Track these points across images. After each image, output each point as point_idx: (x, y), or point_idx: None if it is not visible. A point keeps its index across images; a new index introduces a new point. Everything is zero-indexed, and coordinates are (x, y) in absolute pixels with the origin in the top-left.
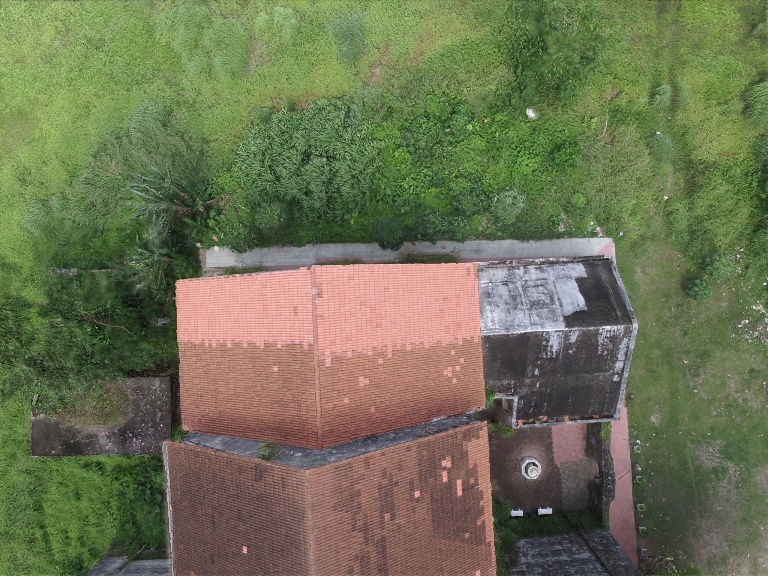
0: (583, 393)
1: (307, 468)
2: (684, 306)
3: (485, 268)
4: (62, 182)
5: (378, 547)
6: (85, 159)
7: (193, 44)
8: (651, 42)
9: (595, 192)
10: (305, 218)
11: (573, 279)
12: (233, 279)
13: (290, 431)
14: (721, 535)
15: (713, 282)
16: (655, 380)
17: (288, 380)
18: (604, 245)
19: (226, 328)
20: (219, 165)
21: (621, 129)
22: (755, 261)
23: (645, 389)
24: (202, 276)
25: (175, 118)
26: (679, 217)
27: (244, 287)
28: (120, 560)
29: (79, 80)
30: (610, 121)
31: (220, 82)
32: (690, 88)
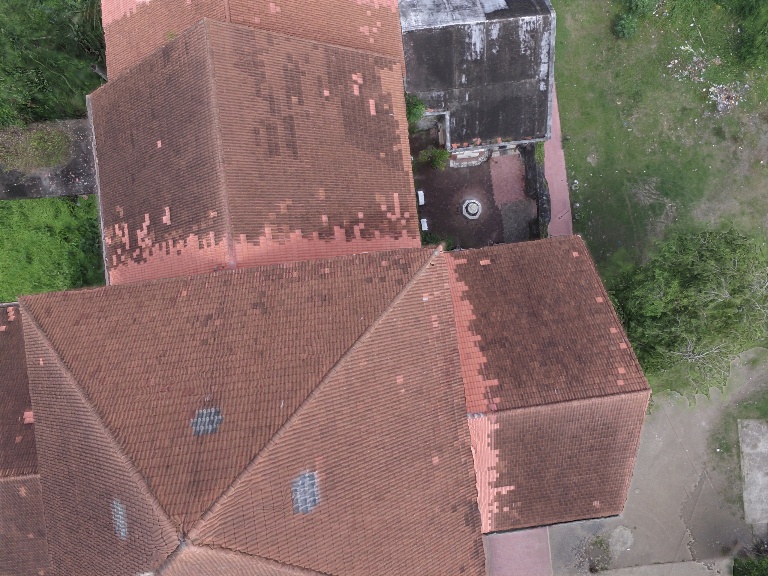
0: (512, 107)
1: None
2: (615, 49)
3: None
4: None
5: (285, 123)
6: None
7: None
8: None
9: None
10: None
11: None
12: None
13: None
14: None
15: (642, 25)
16: (590, 122)
17: (200, 5)
18: None
19: None
20: None
21: None
22: (681, 1)
23: (580, 131)
24: None
25: None
26: None
27: None
28: None
29: None
30: None
31: None
32: None
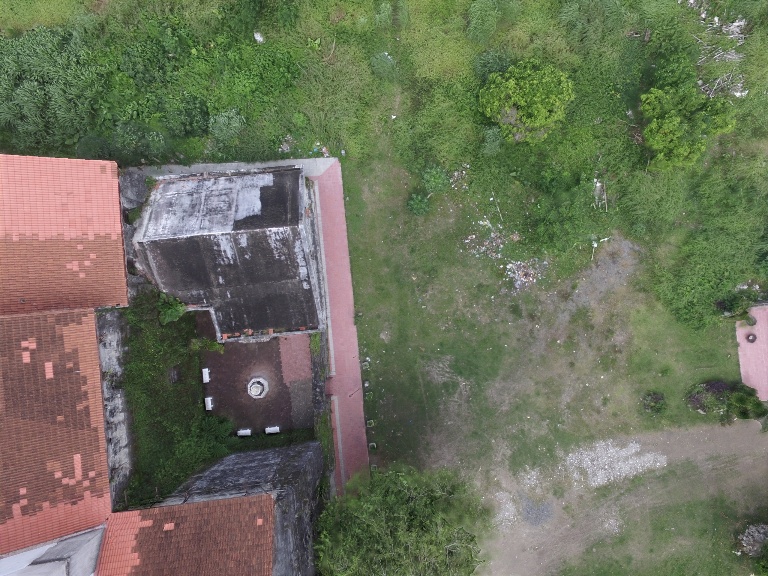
0: (279, 303)
1: None
2: (411, 223)
3: (177, 181)
4: None
5: None
6: None
7: None
8: None
9: (316, 111)
10: (23, 144)
11: (258, 188)
12: None
13: None
14: (452, 449)
15: (440, 199)
16: (384, 297)
17: None
18: (330, 165)
19: None
20: None
21: (343, 49)
22: (479, 176)
23: (374, 306)
24: None
25: None
26: (402, 134)
27: None
28: None
29: None
30: (337, 43)
31: None
32: (417, 8)
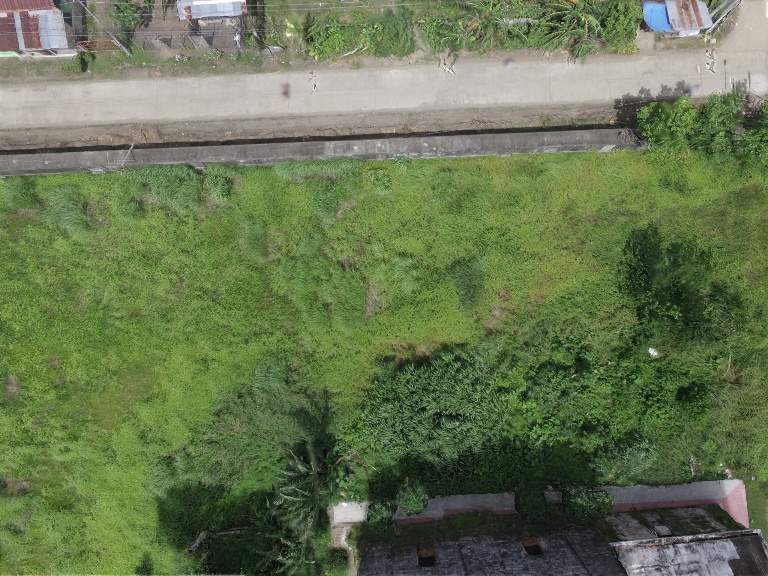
0: None
1: None
2: None
3: (634, 548)
4: (184, 439)
5: None
6: (207, 416)
7: (313, 297)
8: None
9: (725, 437)
10: (437, 478)
11: (726, 562)
12: None
13: None
14: None
15: None
16: None
17: None
18: (734, 487)
19: None
20: (345, 422)
21: (748, 371)
22: None
23: None
24: (331, 532)
25: (298, 373)
26: None
27: None
28: None
29: (197, 334)
30: (734, 358)
31: (340, 332)
32: None
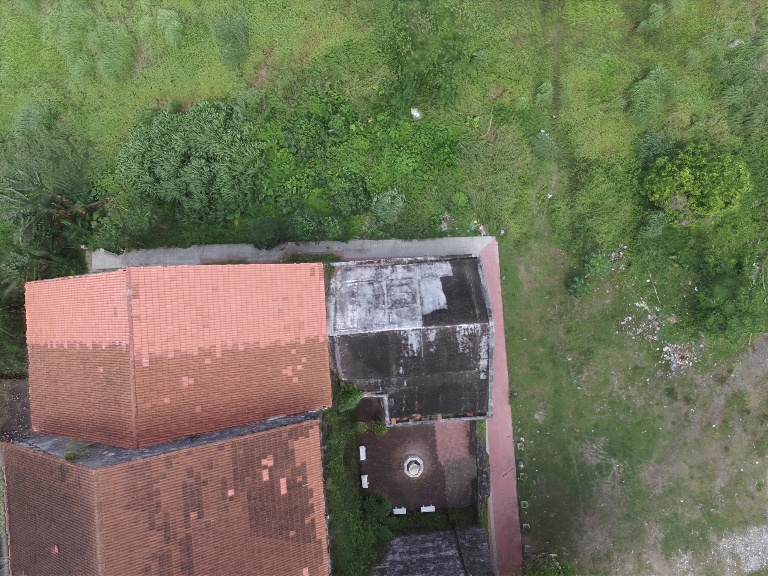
0: (452, 391)
1: (95, 468)
2: (567, 304)
3: (354, 268)
4: None
5: (182, 545)
6: None
7: (78, 47)
8: (536, 41)
9: (476, 191)
10: (186, 219)
11: (438, 278)
12: (68, 281)
13: (112, 431)
14: (605, 531)
15: (596, 279)
16: (539, 377)
17: (110, 381)
18: (487, 243)
19: (64, 330)
20: (103, 167)
21: (503, 128)
22: (637, 258)
23: (529, 387)
24: None
25: (60, 121)
26: (561, 215)
27: (77, 289)
28: (0, 560)
29: None
30: (494, 120)
31: (106, 85)
32: (574, 86)
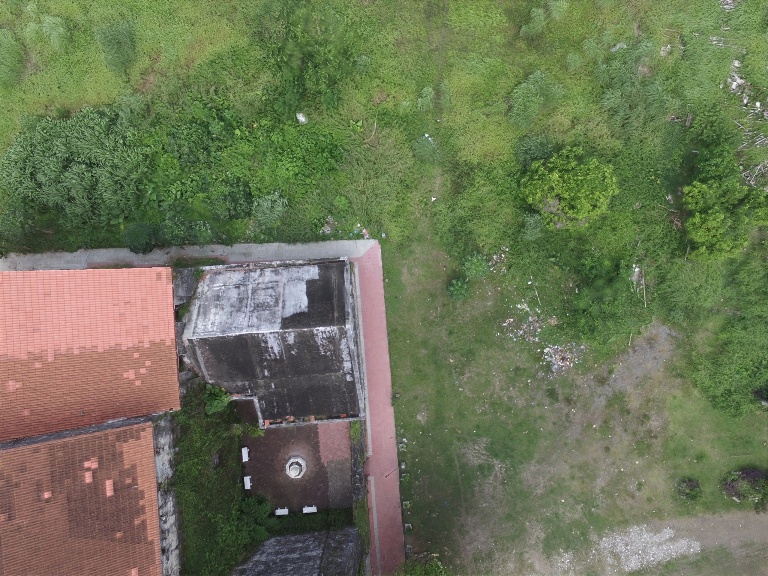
0: (321, 393)
1: None
2: (449, 306)
3: (223, 271)
4: None
5: None
6: None
7: None
8: (420, 45)
9: (358, 194)
10: (70, 224)
11: (304, 281)
12: None
13: None
14: (487, 531)
15: (479, 282)
16: (421, 379)
17: None
18: (370, 247)
19: None
20: None
21: (385, 132)
22: (518, 260)
23: (411, 388)
24: None
25: None
26: (442, 218)
27: None
28: None
29: None
30: (378, 124)
31: None
32: (458, 90)
